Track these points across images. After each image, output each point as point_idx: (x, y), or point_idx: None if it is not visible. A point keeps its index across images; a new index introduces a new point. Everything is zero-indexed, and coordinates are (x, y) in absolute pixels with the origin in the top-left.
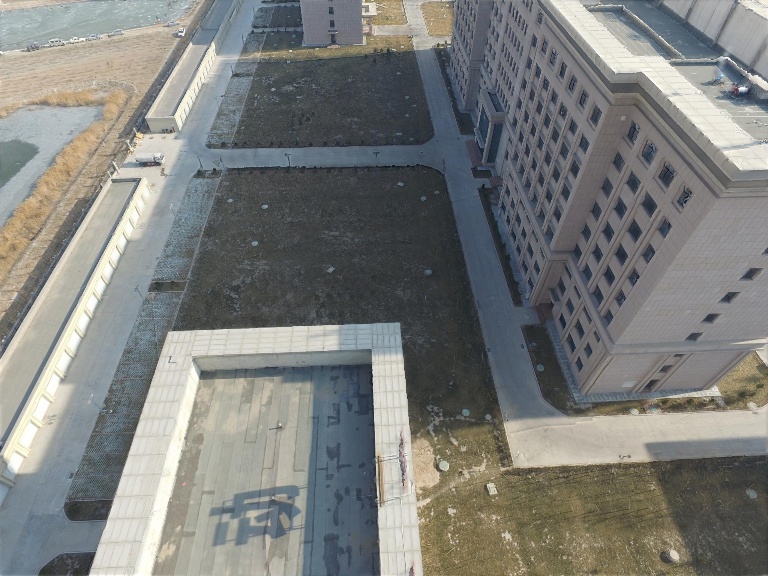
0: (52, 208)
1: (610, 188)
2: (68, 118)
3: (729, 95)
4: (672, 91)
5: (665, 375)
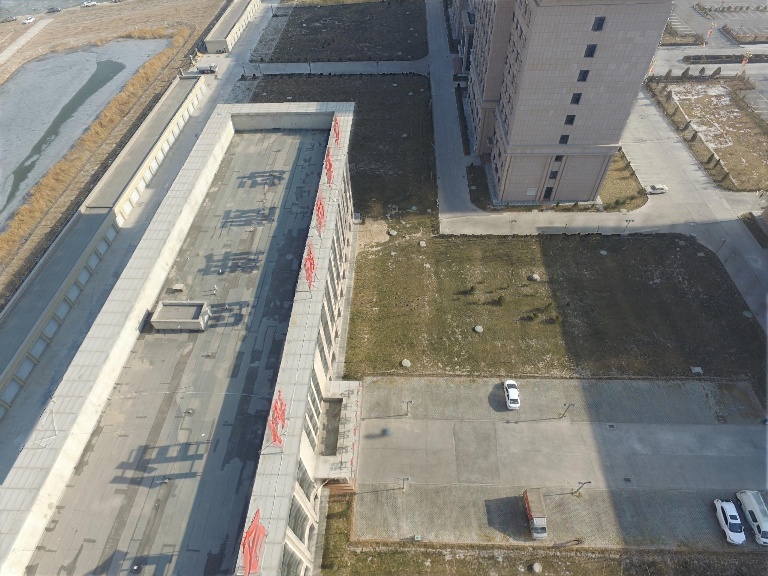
0: (137, 99)
1: None
2: (146, 46)
3: None
4: None
5: (555, 181)
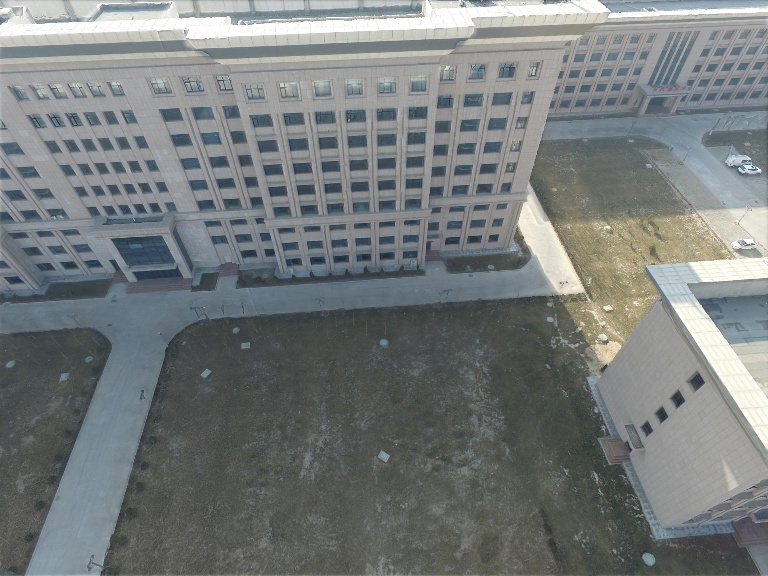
0: None
1: (442, 125)
2: None
3: (482, 5)
4: (505, 13)
5: None
